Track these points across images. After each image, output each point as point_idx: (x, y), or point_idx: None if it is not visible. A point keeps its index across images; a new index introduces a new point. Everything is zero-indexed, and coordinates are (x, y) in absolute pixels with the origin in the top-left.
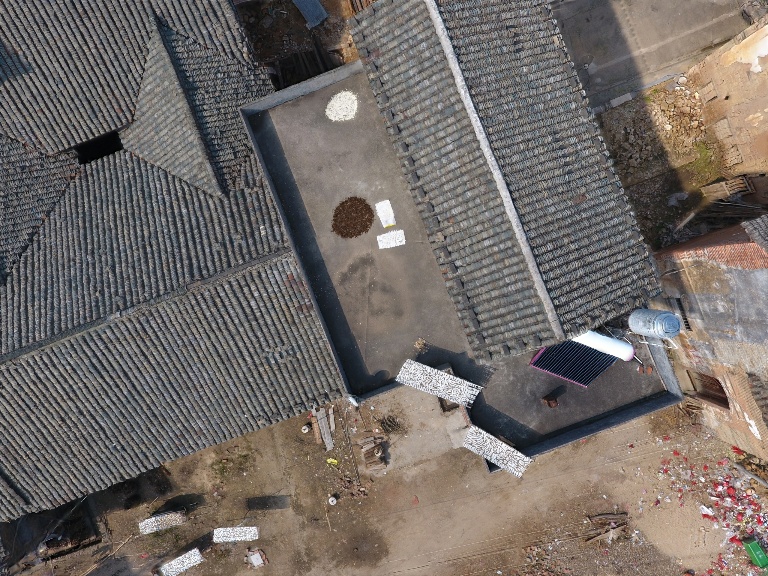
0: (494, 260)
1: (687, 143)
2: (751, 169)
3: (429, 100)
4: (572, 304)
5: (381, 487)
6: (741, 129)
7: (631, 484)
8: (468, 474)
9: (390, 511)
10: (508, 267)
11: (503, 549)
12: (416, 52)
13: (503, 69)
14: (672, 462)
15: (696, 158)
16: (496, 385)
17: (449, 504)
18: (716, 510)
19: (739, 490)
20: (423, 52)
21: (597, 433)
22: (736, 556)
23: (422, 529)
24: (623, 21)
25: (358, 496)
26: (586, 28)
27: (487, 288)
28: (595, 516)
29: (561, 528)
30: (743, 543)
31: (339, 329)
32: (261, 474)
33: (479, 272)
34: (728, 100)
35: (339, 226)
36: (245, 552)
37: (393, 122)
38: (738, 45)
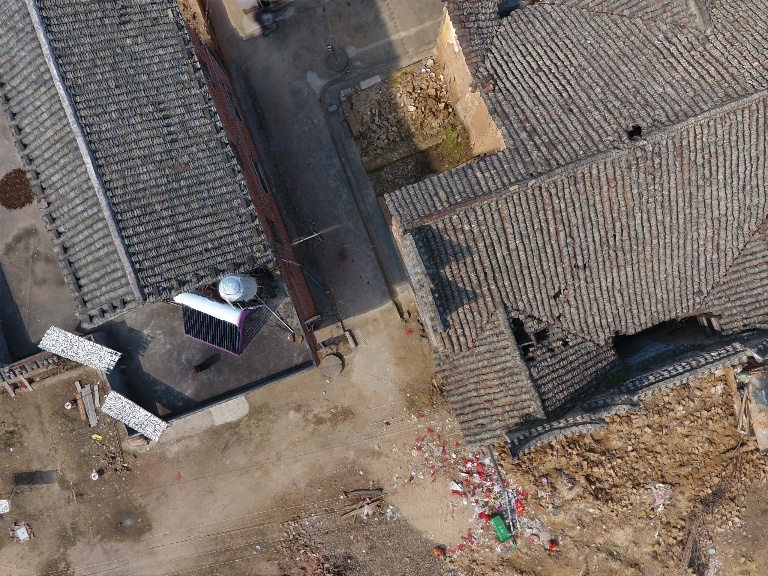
0: (85, 225)
1: (434, 124)
2: (479, 149)
3: (25, 69)
4: (157, 268)
5: (144, 463)
6: (466, 109)
7: (387, 460)
8: (229, 450)
9: (153, 486)
10: (96, 232)
11: (262, 524)
12: (12, 22)
13: (102, 40)
14: (426, 439)
15: (443, 139)
16: (153, 353)
17: (210, 480)
18: (465, 486)
19: (488, 466)
20: (18, 22)
21: (231, 398)
22: (485, 531)
23: (184, 504)
24: (383, 5)
25: (121, 471)
26: (347, 11)
27: (84, 253)
28: (351, 492)
29: (318, 503)
30: (490, 518)
31: (3, 298)
32: (28, 450)
33: (76, 237)
34: (455, 81)
35: (3, 197)
36: (12, 526)
37: (3, 91)
38: (444, 25)
